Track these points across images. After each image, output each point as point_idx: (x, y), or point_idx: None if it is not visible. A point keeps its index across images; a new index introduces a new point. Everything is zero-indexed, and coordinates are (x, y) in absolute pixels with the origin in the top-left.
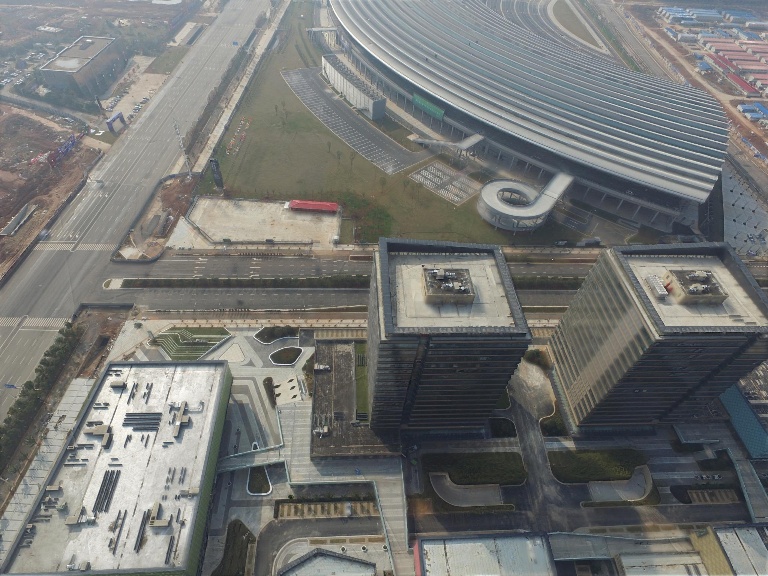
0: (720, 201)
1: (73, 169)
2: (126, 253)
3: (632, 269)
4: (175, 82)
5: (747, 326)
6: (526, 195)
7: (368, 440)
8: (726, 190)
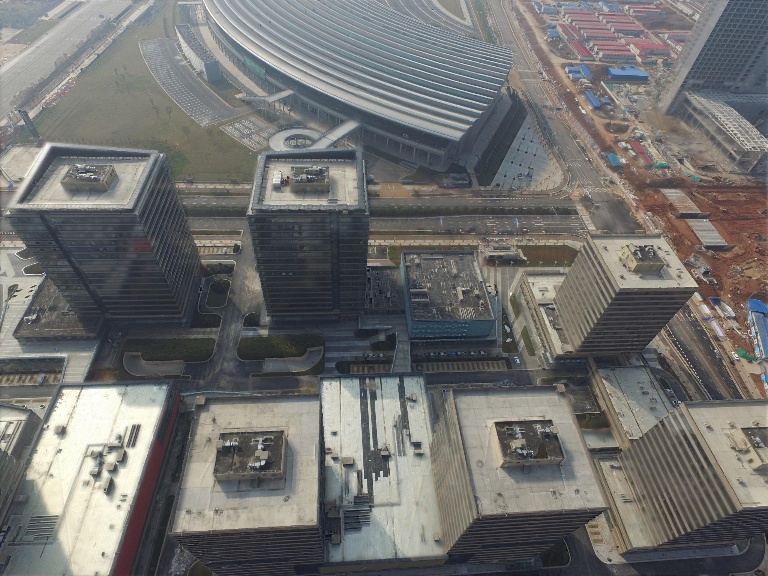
0: (507, 147)
1: None
2: None
3: (271, 169)
4: (32, 51)
5: (330, 205)
6: (315, 140)
7: (71, 325)
8: (518, 138)
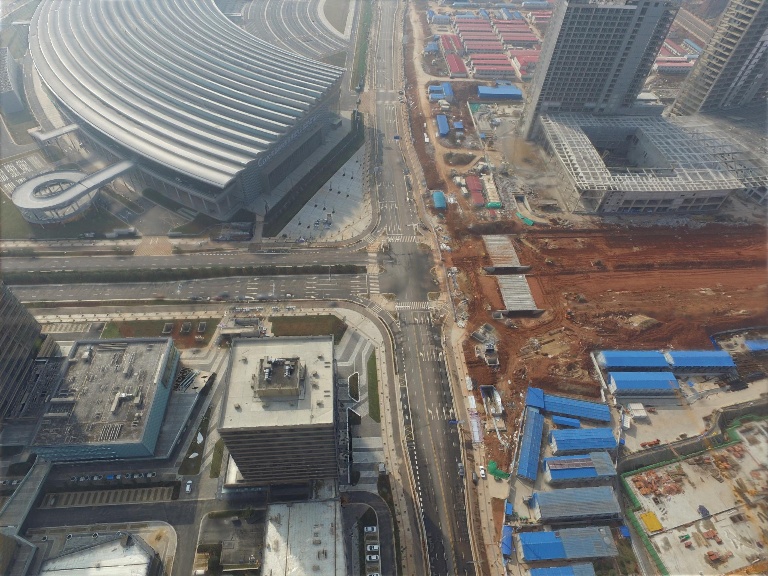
0: (318, 186)
1: None
2: None
3: None
4: None
5: None
6: None
7: None
8: (338, 174)
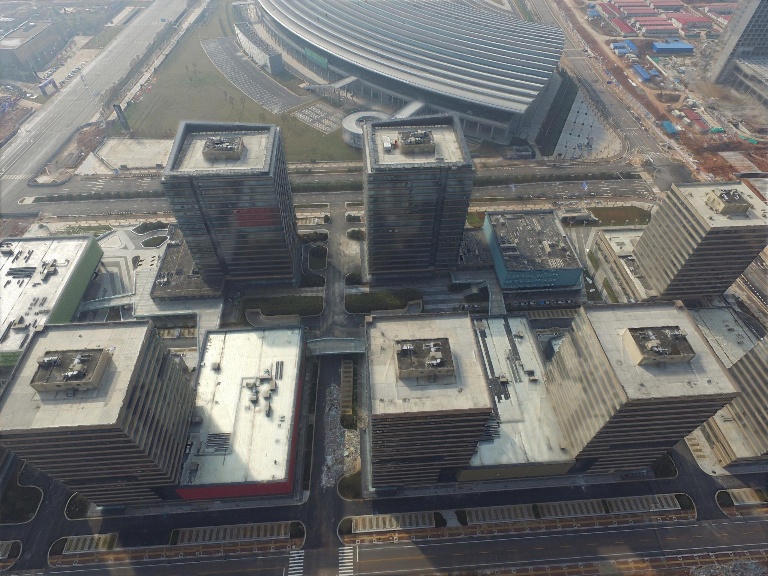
0: (563, 120)
1: (8, 123)
2: (41, 180)
3: (377, 135)
4: (106, 55)
5: (440, 162)
6: None
7: (197, 286)
8: (573, 111)
